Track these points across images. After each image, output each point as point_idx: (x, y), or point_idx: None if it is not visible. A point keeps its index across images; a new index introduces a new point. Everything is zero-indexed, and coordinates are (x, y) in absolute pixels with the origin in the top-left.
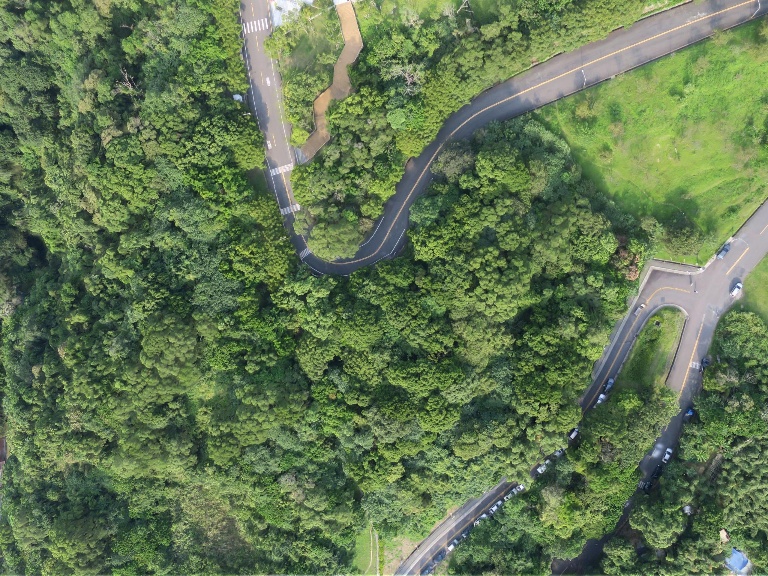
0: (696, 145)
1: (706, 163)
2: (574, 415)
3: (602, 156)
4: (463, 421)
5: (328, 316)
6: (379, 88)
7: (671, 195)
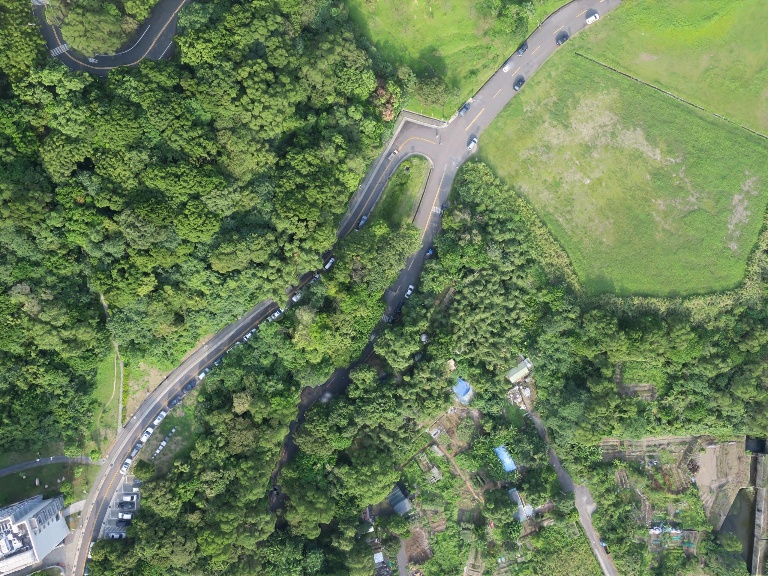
0: (447, 8)
1: (454, 26)
2: (330, 233)
3: (368, 1)
4: (222, 234)
5: (81, 109)
6: None
7: (424, 52)
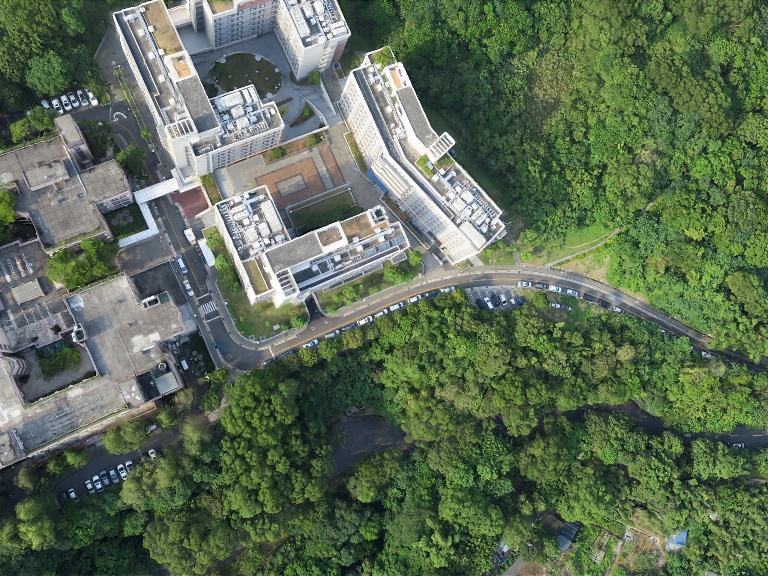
0: None
1: None
2: None
3: None
4: None
5: None
6: None
7: None
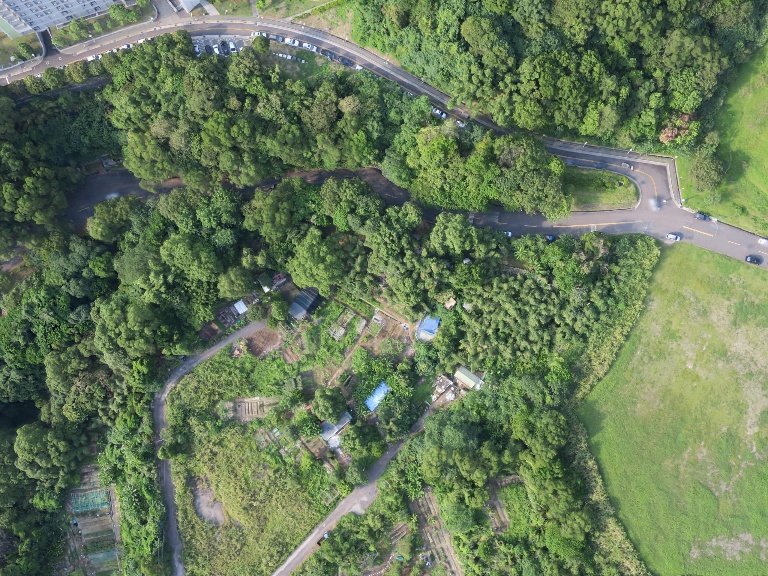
0: None
1: None
2: (536, 114)
3: (764, 76)
4: (496, 19)
5: None
6: None
7: (740, 155)
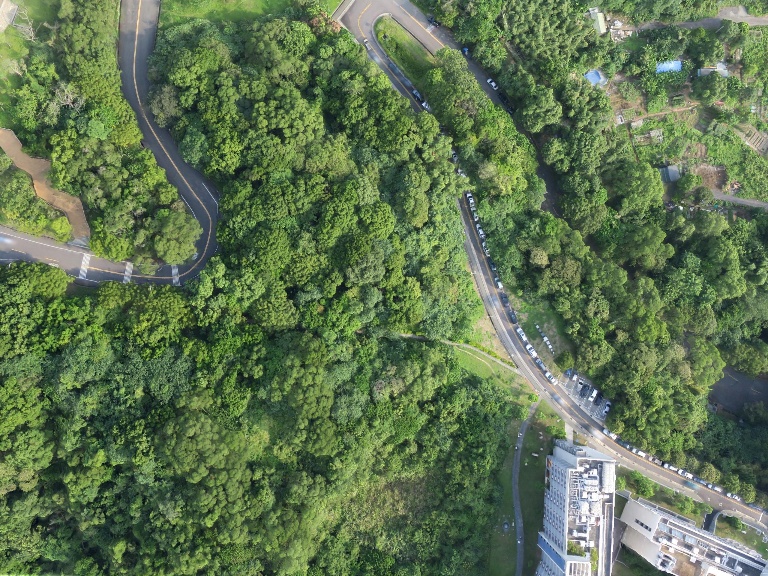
0: None
1: None
2: (427, 115)
3: None
4: (394, 205)
5: (244, 273)
6: (60, 129)
7: None
